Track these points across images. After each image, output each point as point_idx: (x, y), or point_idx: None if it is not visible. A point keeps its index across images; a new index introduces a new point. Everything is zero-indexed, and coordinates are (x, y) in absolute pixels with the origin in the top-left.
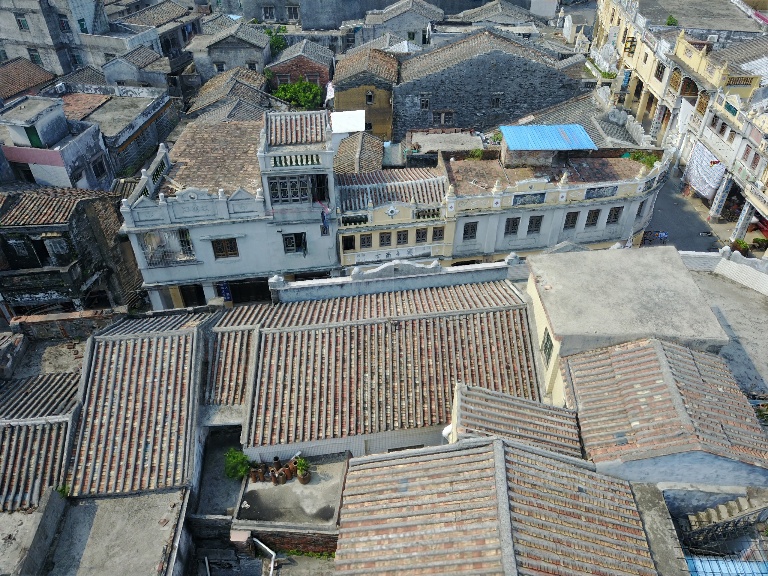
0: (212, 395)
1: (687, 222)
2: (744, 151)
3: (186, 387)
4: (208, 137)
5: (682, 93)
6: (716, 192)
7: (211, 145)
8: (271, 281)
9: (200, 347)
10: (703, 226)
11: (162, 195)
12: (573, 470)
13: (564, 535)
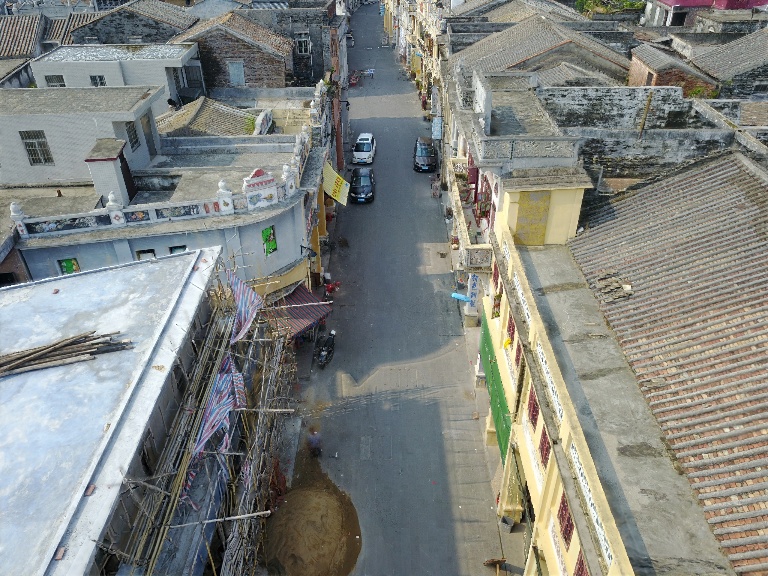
0: (48, 37)
1: (394, 72)
2: (409, 17)
3: (35, 29)
4: (72, 2)
5: (399, 4)
6: (406, 50)
7: (73, 3)
8: (84, 11)
9: (42, 18)
10: (403, 73)
11: (35, 2)
12: (174, 9)
13: (157, 10)
